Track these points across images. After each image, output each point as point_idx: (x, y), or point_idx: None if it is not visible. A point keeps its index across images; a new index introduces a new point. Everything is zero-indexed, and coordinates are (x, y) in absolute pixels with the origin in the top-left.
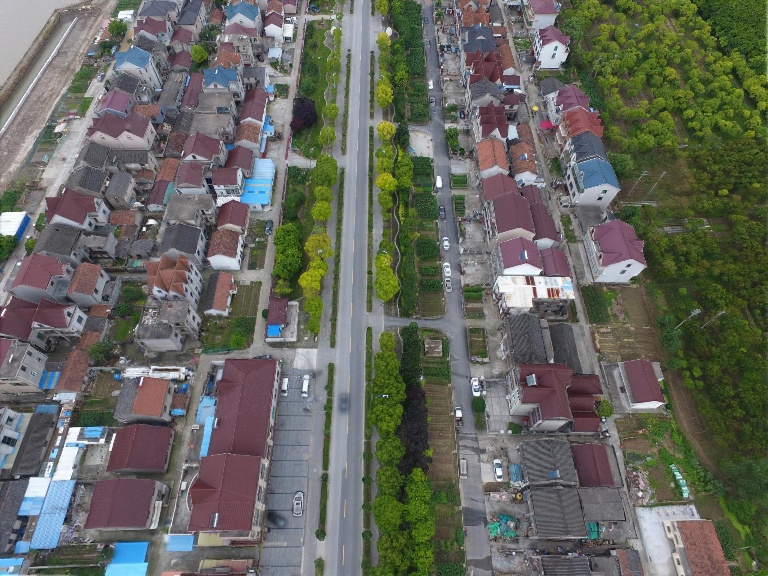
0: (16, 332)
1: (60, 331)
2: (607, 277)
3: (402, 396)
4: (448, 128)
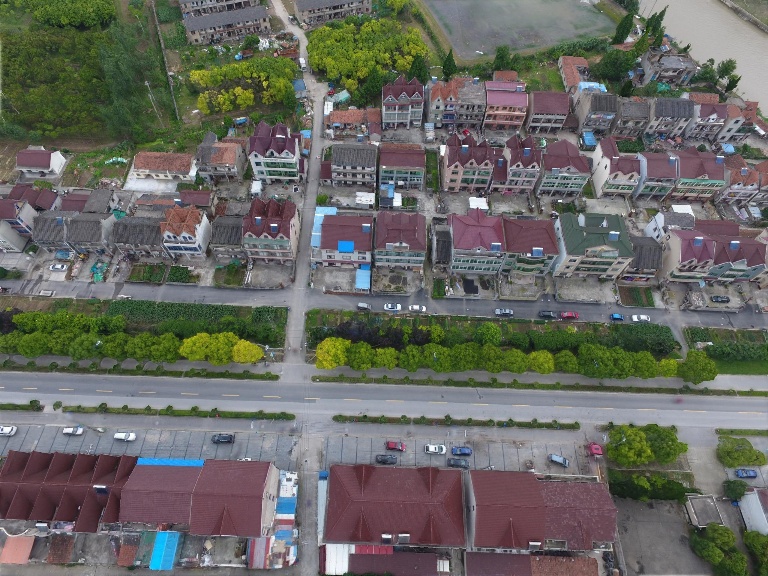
0: None
1: None
2: None
3: None
4: None
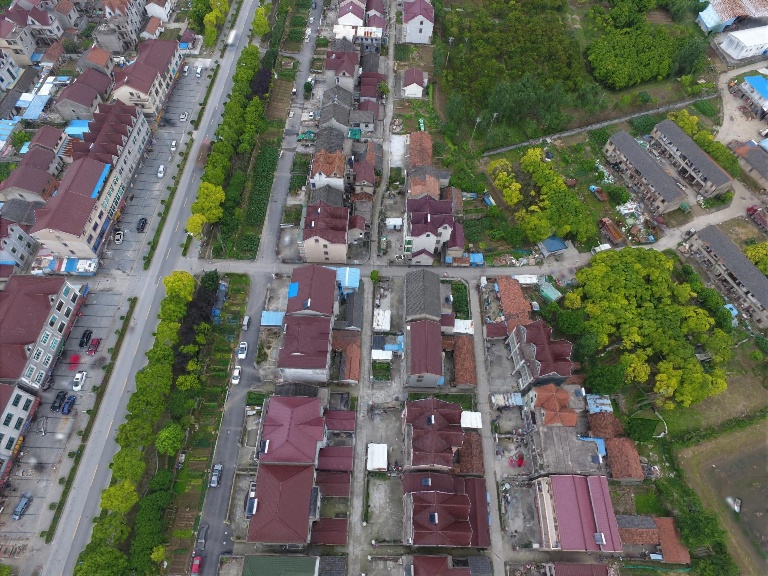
0: (17, 22)
1: (45, 33)
2: (412, 37)
3: (255, 69)
4: None
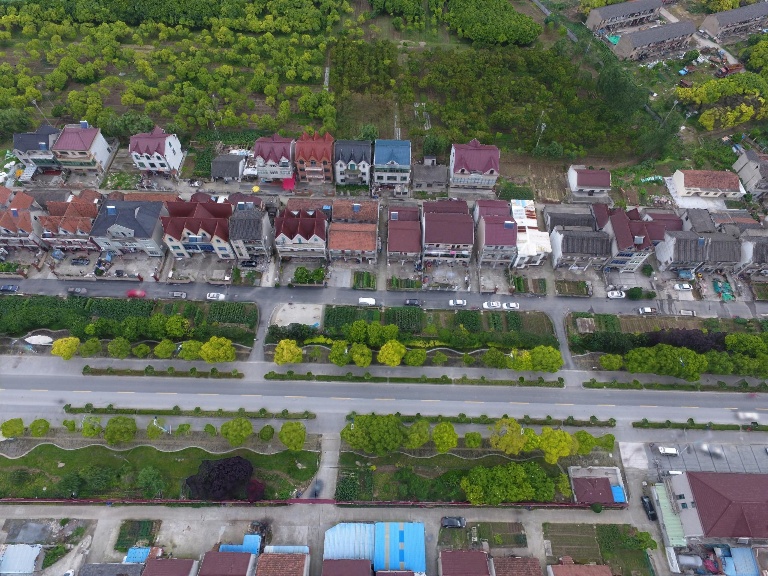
0: None
1: None
2: None
3: None
4: (277, 281)
